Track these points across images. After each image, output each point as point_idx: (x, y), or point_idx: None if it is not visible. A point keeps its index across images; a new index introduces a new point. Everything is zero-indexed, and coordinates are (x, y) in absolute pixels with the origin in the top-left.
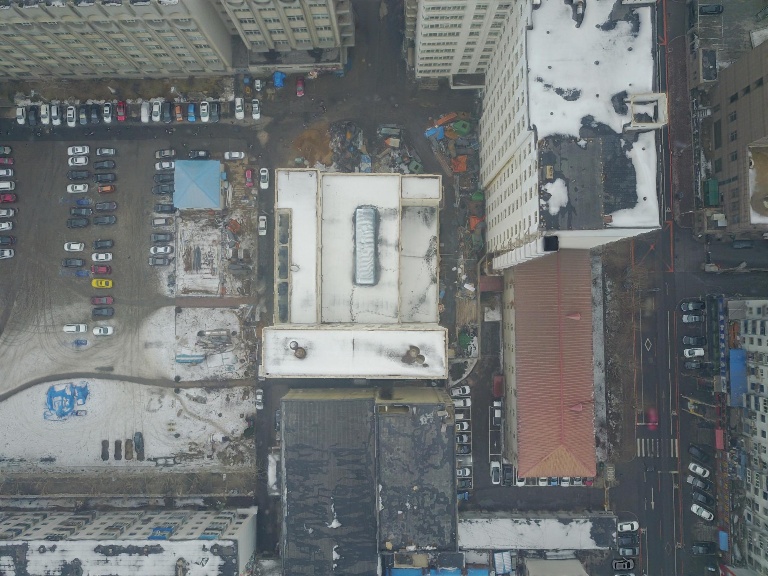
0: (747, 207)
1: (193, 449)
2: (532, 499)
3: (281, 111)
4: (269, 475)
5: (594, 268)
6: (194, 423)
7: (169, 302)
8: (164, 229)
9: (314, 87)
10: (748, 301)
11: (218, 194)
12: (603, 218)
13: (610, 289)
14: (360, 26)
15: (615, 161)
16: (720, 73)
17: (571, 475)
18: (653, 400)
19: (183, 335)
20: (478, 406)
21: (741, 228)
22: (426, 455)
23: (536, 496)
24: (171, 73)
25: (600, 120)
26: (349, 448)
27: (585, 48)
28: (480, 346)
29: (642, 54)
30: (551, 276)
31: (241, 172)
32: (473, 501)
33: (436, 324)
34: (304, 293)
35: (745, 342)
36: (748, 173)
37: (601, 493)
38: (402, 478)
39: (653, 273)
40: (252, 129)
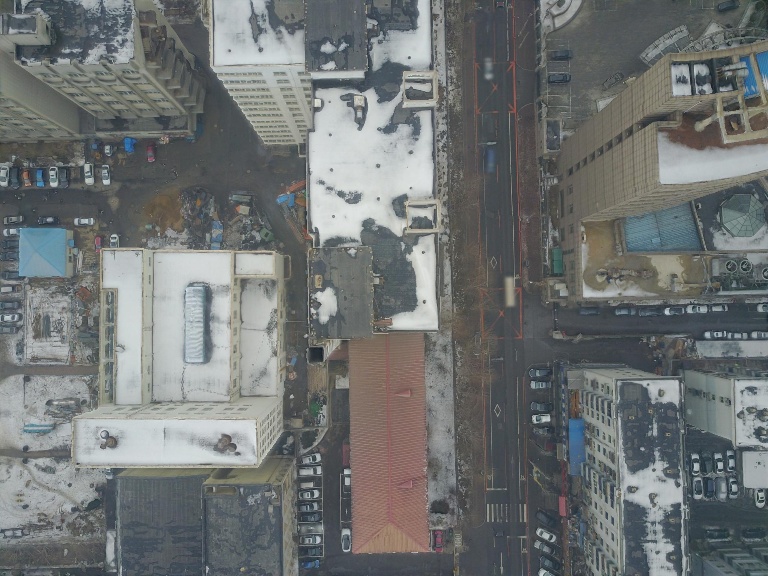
0: (579, 281)
1: (42, 520)
2: (383, 566)
3: (132, 176)
4: (107, 552)
5: (444, 335)
6: (43, 494)
7: (18, 371)
8: (13, 296)
9: (166, 152)
10: (585, 372)
11: (64, 263)
12: (381, 322)
13: (460, 355)
14: (212, 91)
15: (396, 264)
16: (563, 144)
17: (404, 550)
18: (502, 465)
19: (31, 404)
20: (329, 473)
21: (577, 300)
22: (253, 536)
23: (387, 563)
24: (19, 138)
25: (381, 223)
26: (184, 525)
27: (367, 151)
28: (328, 415)
29: (423, 157)
30: (380, 354)
31: (92, 238)
32: (324, 569)
33: (276, 398)
34: (130, 374)
35: (584, 411)
36: (581, 248)
37: (451, 559)
38: (229, 559)
39: (502, 339)
40: (103, 195)
